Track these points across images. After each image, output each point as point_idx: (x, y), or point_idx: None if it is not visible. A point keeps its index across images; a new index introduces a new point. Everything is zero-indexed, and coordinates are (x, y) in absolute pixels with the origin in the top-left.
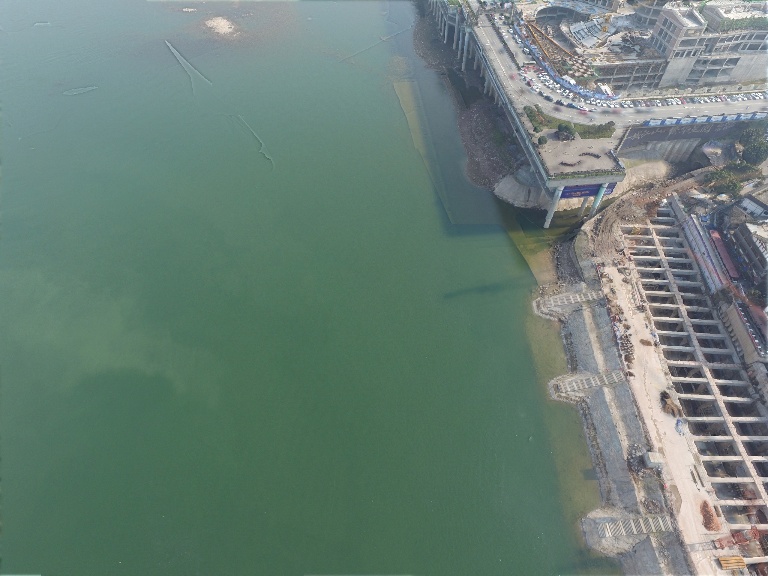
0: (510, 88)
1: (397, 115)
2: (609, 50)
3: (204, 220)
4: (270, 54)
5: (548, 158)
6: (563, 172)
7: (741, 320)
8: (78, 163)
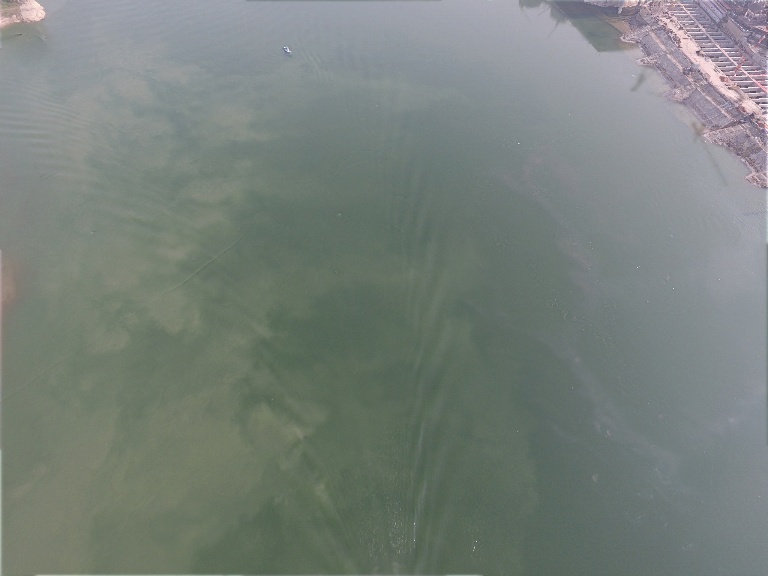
0: None
1: None
2: None
3: (415, 17)
4: None
5: None
6: None
7: (733, 23)
8: None
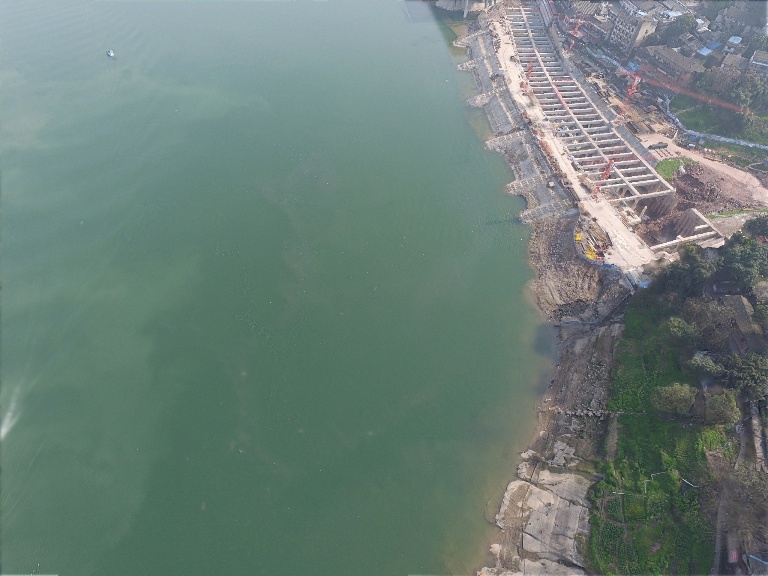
0: None
1: None
2: None
3: (261, 21)
4: None
5: None
6: None
7: (554, 28)
8: (172, 3)
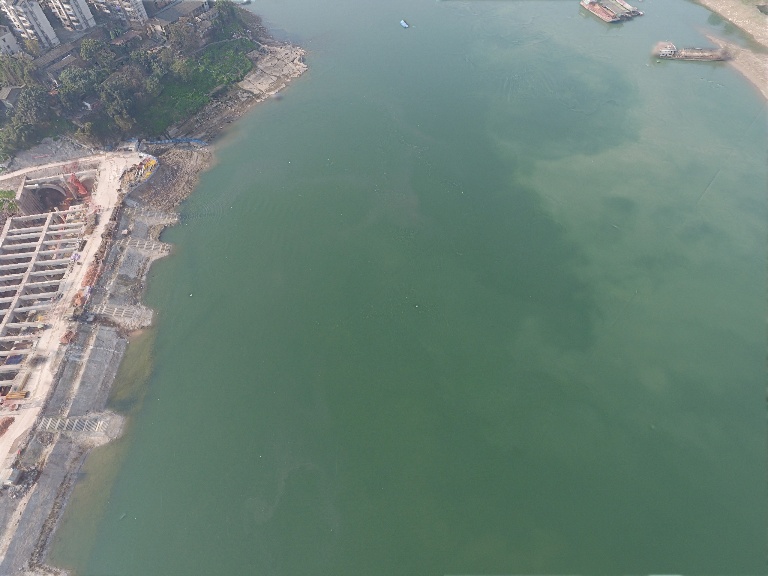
0: None
1: None
2: None
3: None
4: None
5: None
6: None
7: None
8: None
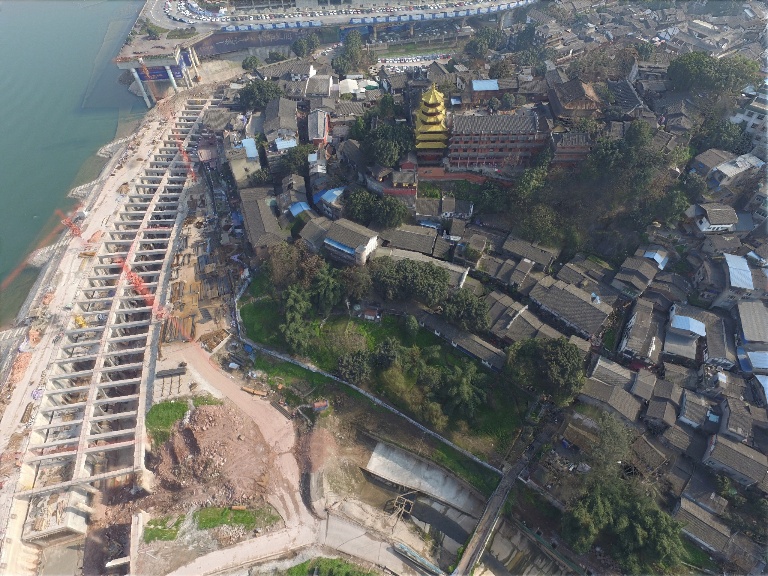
0: (148, 11)
1: (97, 43)
2: None
3: None
4: (26, 5)
5: (128, 50)
6: (126, 57)
7: None
8: None
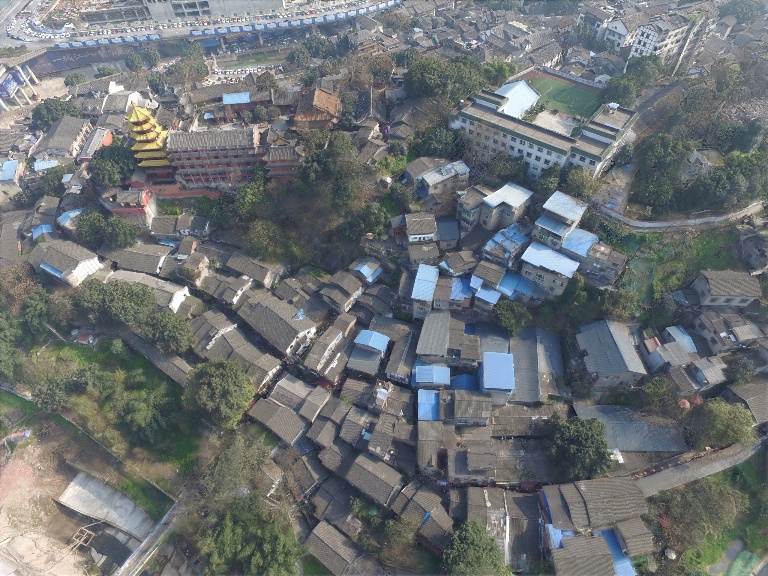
0: None
1: None
2: (109, 1)
3: None
4: None
5: None
6: None
7: None
8: None
